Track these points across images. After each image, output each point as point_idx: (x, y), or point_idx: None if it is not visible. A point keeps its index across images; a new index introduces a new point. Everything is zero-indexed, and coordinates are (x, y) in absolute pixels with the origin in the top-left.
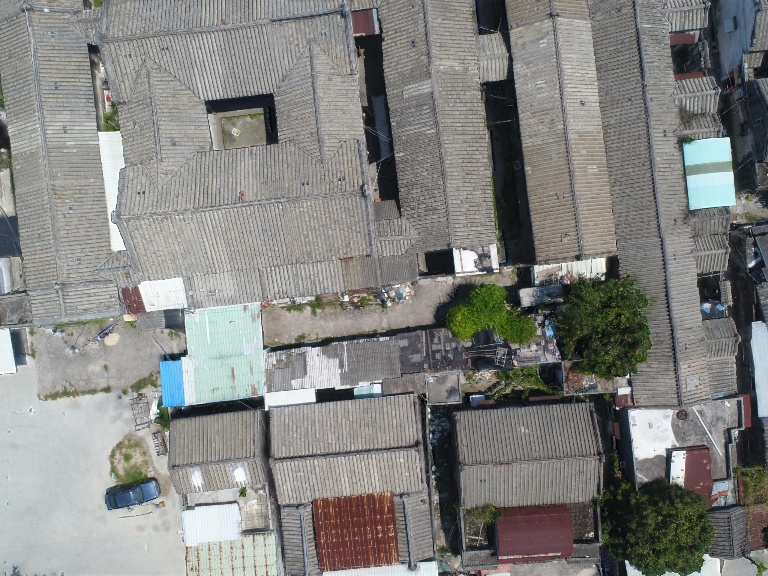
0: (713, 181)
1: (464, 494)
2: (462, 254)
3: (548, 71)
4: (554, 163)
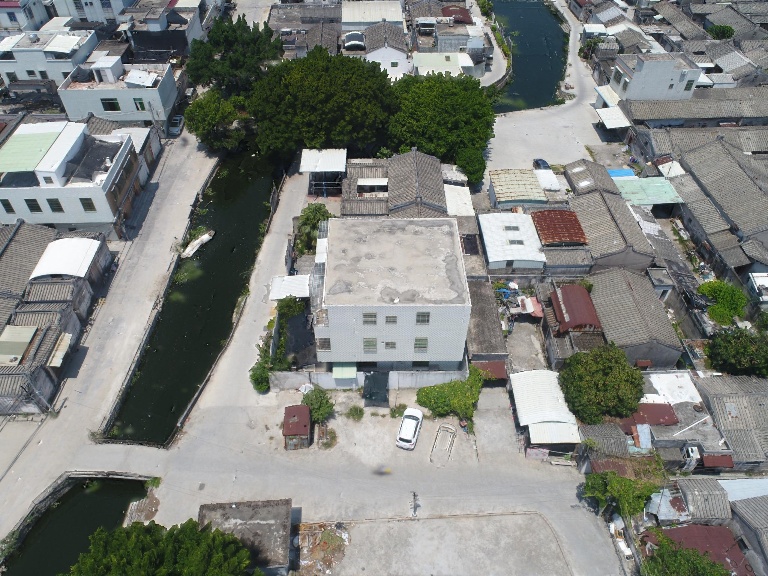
0: None
1: (597, 275)
2: (765, 278)
3: None
4: None
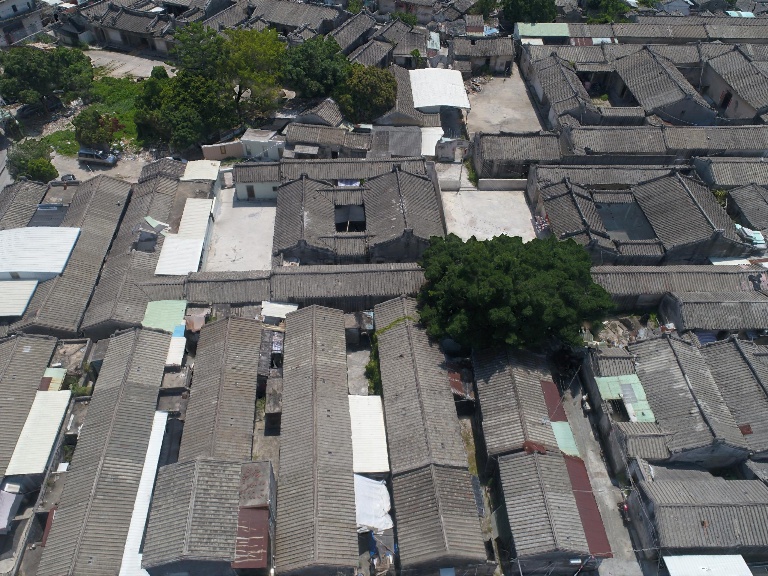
0: (742, 12)
1: None
2: None
3: (726, 28)
4: (761, 30)
